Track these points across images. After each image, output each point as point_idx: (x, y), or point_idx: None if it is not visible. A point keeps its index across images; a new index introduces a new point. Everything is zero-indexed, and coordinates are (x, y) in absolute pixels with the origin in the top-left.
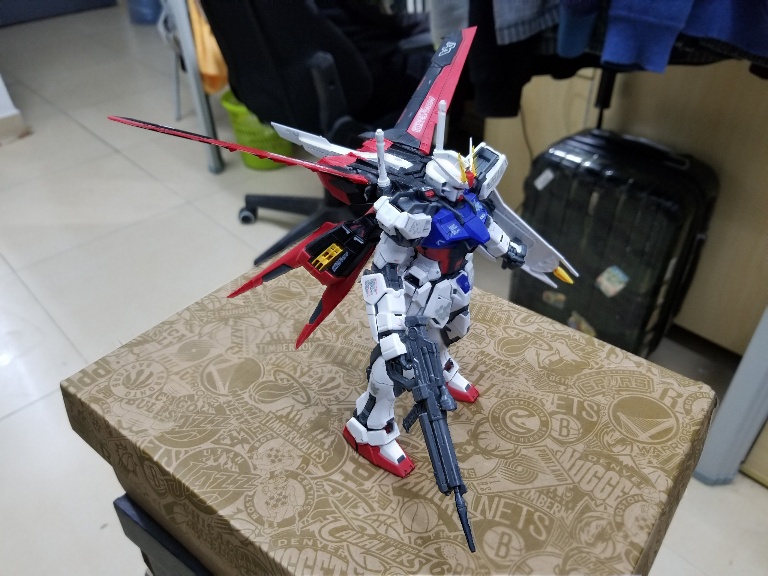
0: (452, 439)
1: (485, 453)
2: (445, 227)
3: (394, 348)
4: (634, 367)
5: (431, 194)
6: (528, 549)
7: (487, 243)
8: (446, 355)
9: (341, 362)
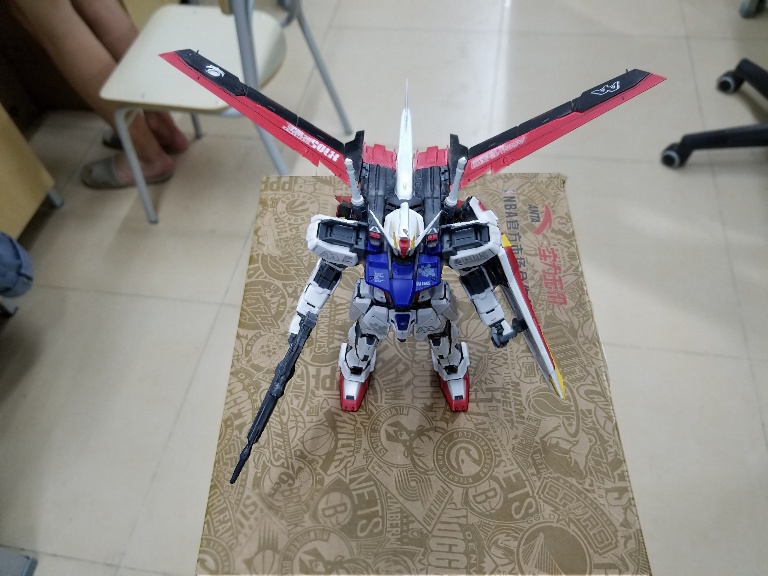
0: (404, 419)
1: (409, 450)
2: (372, 270)
3: (291, 325)
4: (618, 521)
5: (376, 236)
6: (343, 529)
7: None
8: (451, 360)
9: None
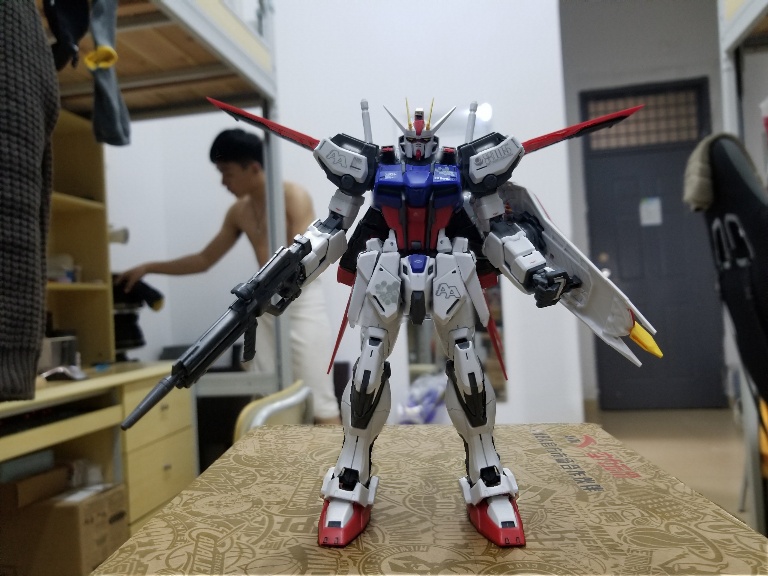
0: (421, 554)
1: None
2: (382, 173)
3: None
4: None
5: None
6: None
7: (510, 260)
8: (489, 457)
9: (432, 480)
